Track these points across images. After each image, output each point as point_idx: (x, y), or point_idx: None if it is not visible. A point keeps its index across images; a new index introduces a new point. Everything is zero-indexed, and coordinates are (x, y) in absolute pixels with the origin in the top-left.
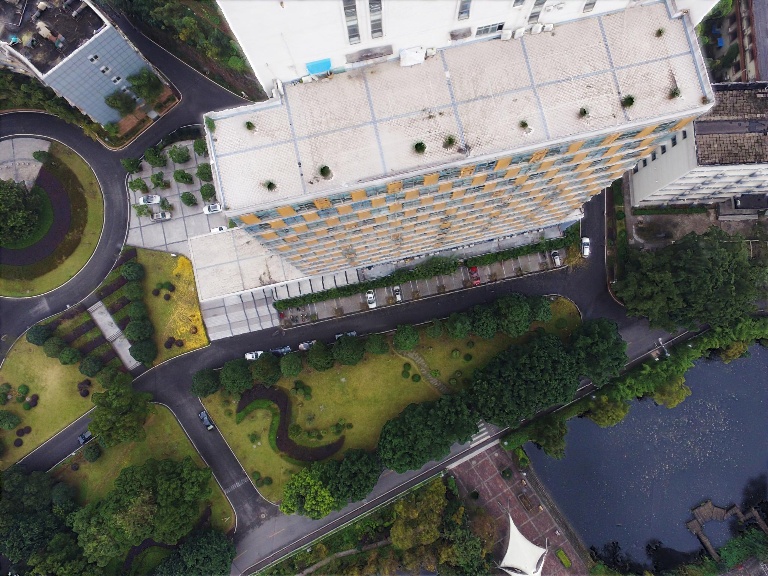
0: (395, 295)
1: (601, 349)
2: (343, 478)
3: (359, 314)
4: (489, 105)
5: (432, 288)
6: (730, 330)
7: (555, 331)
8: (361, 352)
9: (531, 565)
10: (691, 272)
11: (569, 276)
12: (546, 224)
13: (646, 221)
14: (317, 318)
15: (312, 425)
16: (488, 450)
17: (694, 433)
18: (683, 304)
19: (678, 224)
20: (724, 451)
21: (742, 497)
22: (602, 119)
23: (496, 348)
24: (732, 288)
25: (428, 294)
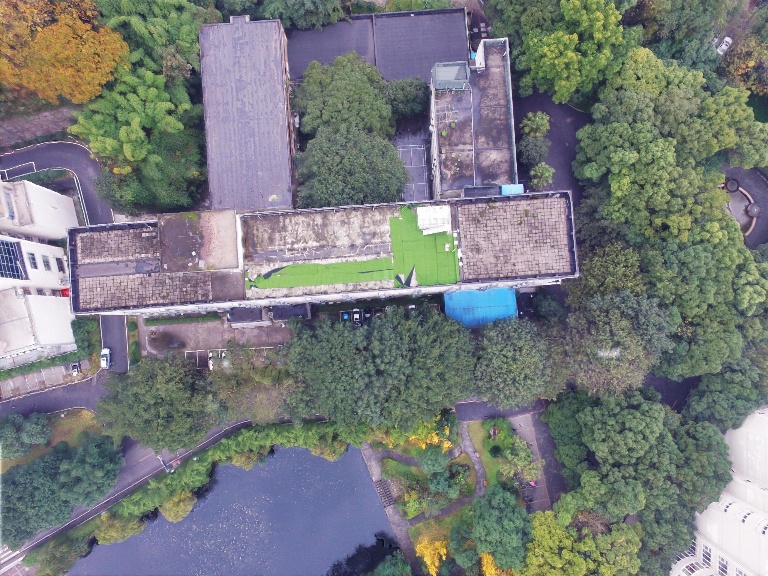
0: None
1: (77, 475)
2: None
3: None
4: None
5: None
6: (233, 442)
7: (78, 445)
8: None
9: None
10: None
11: (93, 388)
12: None
13: (159, 332)
14: None
15: None
16: (18, 565)
17: (228, 537)
18: None
19: (192, 333)
20: (257, 554)
21: None
22: None
23: None
24: (159, 422)
25: None
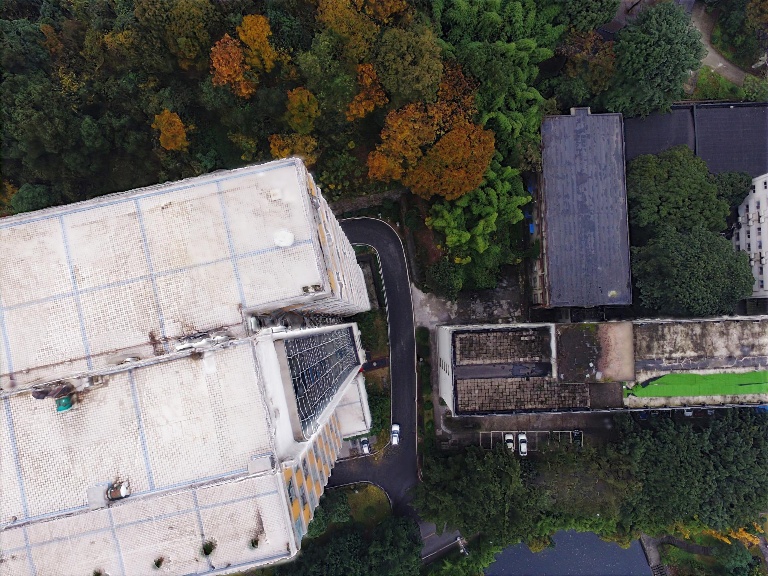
0: None
1: (391, 558)
2: None
3: None
4: (65, 548)
5: None
6: None
7: (364, 519)
8: None
9: None
10: (468, 498)
11: (380, 462)
12: None
13: None
14: None
15: None
16: None
17: None
18: (464, 524)
19: None
20: None
21: None
22: (183, 564)
23: (304, 536)
24: (505, 519)
25: None
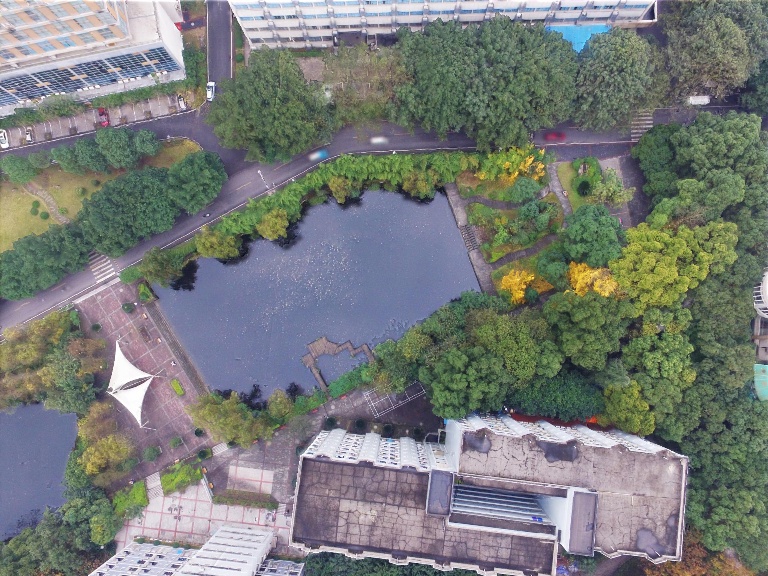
0: None
1: (186, 173)
2: None
3: None
4: None
5: (64, 130)
6: (331, 165)
7: None
8: None
9: (120, 382)
10: None
11: (196, 119)
12: (124, 48)
13: None
14: None
15: None
16: (113, 286)
17: (315, 273)
18: (246, 123)
19: None
20: (342, 290)
21: (356, 333)
22: None
23: None
24: (276, 101)
25: (60, 136)
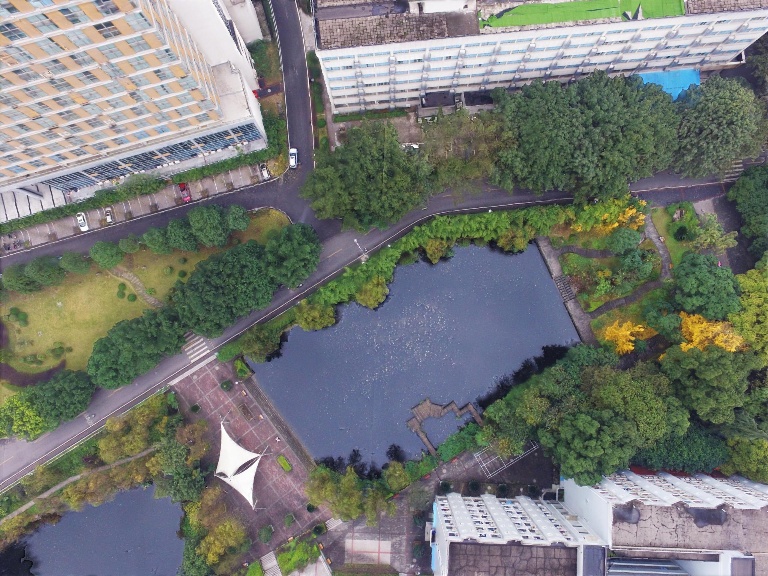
0: (105, 216)
1: (285, 250)
2: (46, 396)
3: (72, 238)
4: None
5: (145, 208)
6: (426, 228)
7: None
8: (56, 270)
9: (232, 467)
10: (348, 164)
11: (280, 188)
12: (215, 127)
13: (348, 128)
14: (31, 245)
15: (32, 351)
16: (208, 364)
17: (412, 335)
18: (349, 198)
19: None
20: (441, 350)
21: (460, 393)
22: None
23: None
24: (383, 176)
25: (141, 214)
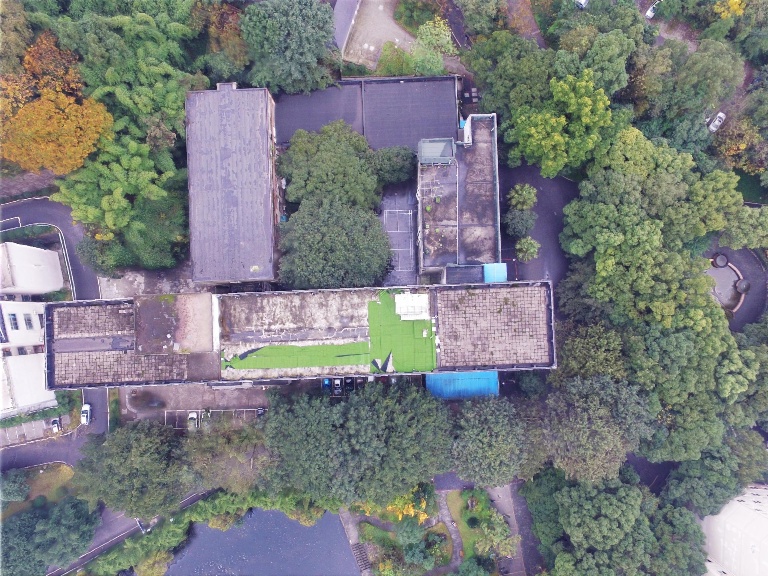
0: None
1: (52, 536)
2: None
3: None
4: None
5: None
6: (209, 505)
7: (57, 499)
8: None
9: None
10: None
11: (73, 443)
12: None
13: (140, 390)
14: None
15: None
16: None
17: None
18: None
19: (172, 393)
20: None
21: None
22: None
23: None
24: (133, 494)
25: None
